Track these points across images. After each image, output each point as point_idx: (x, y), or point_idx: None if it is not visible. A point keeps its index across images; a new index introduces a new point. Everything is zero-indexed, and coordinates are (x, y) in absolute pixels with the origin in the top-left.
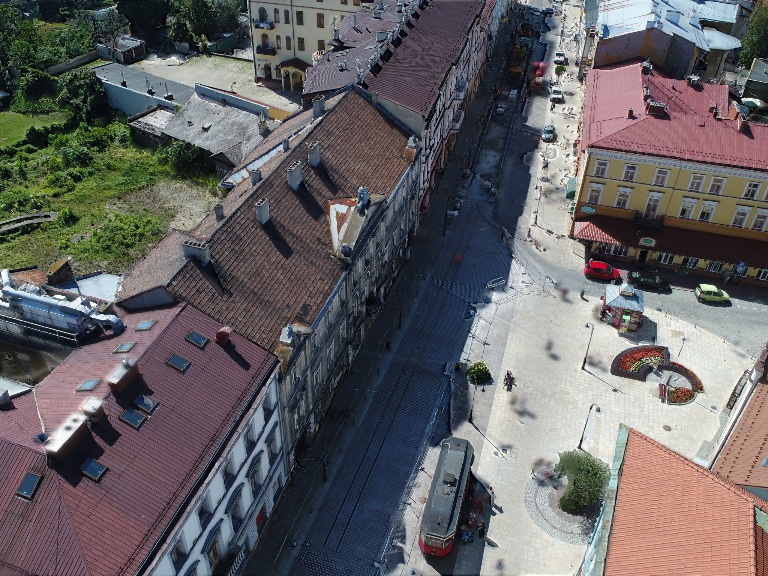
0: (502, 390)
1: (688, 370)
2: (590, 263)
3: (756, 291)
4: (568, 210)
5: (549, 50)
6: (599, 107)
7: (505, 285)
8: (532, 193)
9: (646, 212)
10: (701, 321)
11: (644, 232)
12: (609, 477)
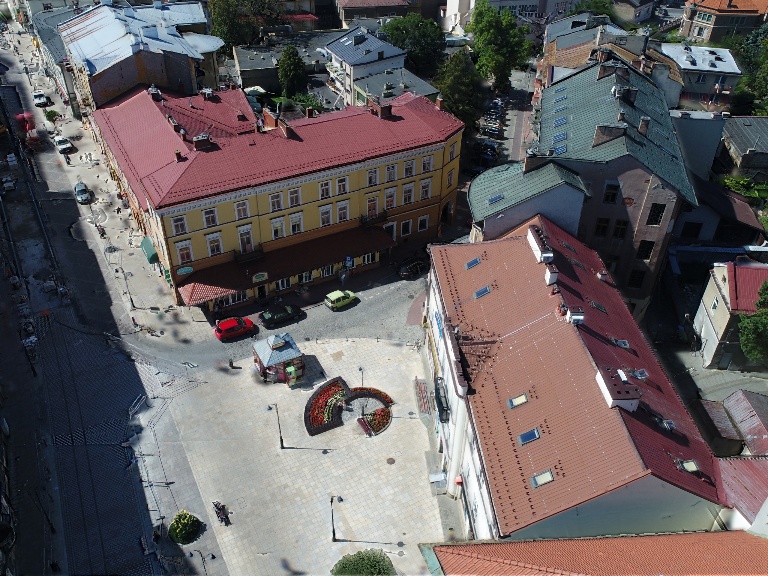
0: (221, 529)
1: (370, 389)
2: (219, 326)
3: (369, 276)
4: (158, 275)
5: (21, 93)
6: (132, 153)
7: (146, 399)
8: (107, 272)
9: (242, 248)
10: (348, 331)
11: (251, 268)
12: (391, 564)
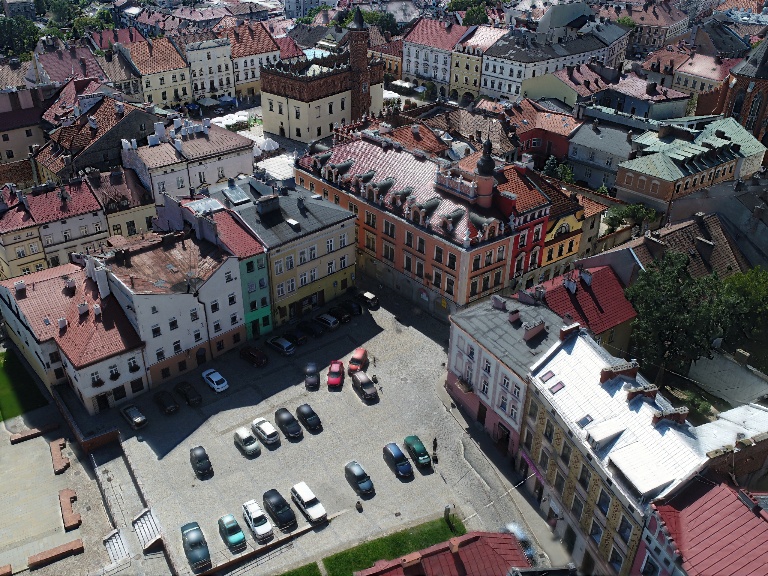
0: None
1: None
2: None
3: None
4: None
5: None
6: None
7: None
8: None
9: None
10: None
11: None
12: None
